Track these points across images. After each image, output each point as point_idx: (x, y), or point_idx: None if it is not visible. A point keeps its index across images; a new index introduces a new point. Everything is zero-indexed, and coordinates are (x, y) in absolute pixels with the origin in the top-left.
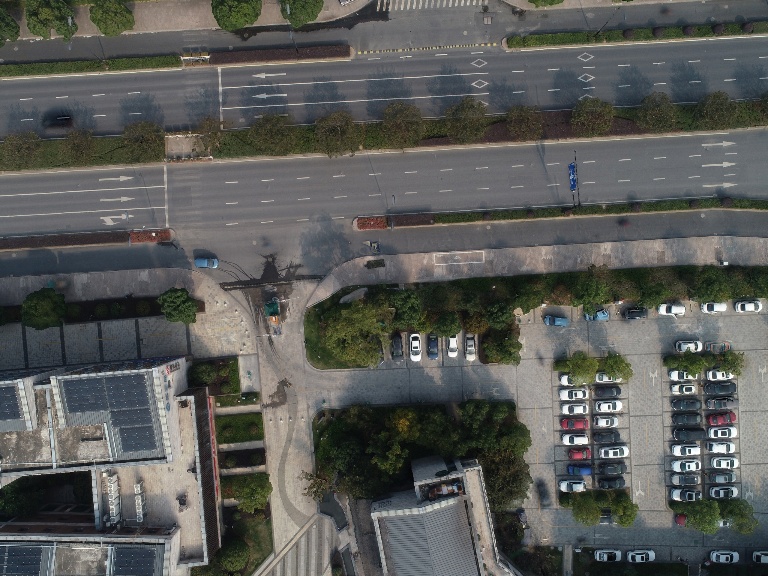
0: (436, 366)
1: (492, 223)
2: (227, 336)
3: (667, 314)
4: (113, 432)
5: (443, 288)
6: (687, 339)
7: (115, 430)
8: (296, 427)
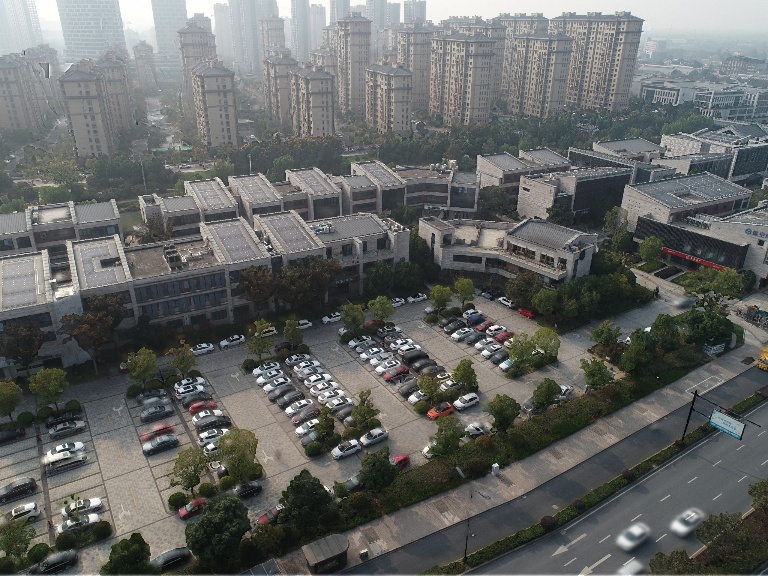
0: (630, 333)
1: None
2: (760, 305)
3: None
4: None
5: (690, 360)
6: (471, 409)
7: None
8: None
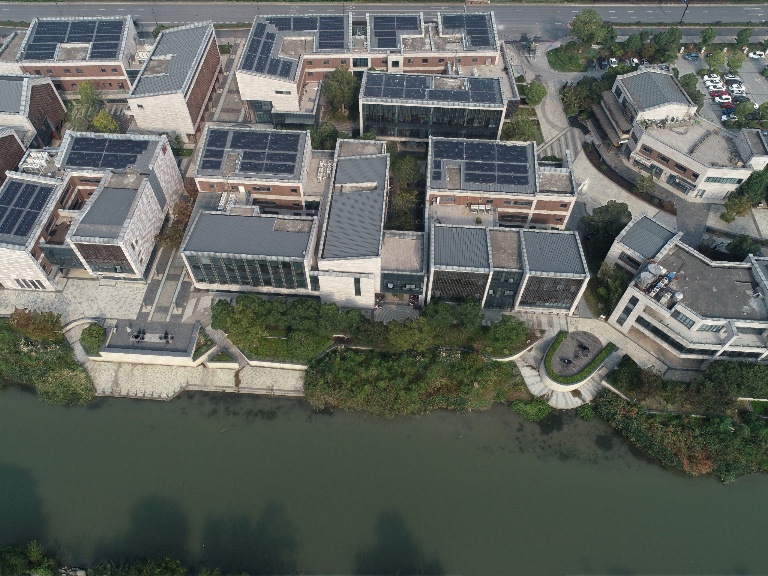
0: None
1: (642, 28)
2: None
3: (754, 56)
4: (467, 38)
5: None
6: None
7: (468, 37)
8: (549, 92)
